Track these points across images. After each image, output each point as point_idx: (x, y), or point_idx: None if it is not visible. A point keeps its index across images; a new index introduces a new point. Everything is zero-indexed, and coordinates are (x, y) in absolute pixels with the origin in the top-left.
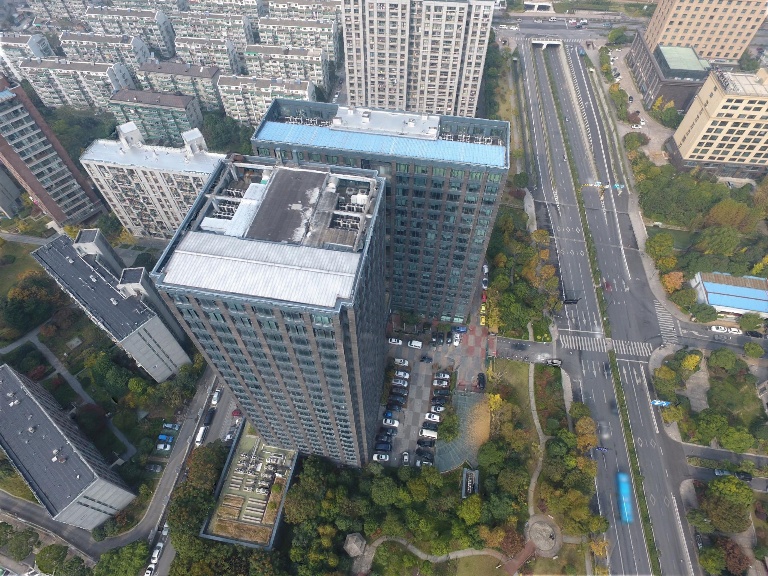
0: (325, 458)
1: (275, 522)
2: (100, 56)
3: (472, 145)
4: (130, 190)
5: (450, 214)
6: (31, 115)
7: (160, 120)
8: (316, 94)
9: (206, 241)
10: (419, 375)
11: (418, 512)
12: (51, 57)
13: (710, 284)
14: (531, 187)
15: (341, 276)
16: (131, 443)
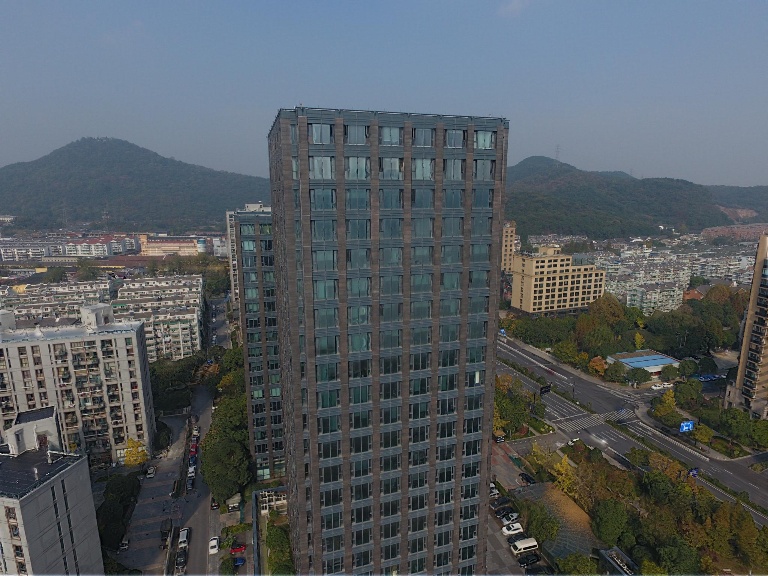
0: None
1: None
2: None
3: None
4: None
5: None
6: None
7: None
8: None
9: None
10: None
11: None
12: None
13: (622, 360)
14: None
15: None
16: None
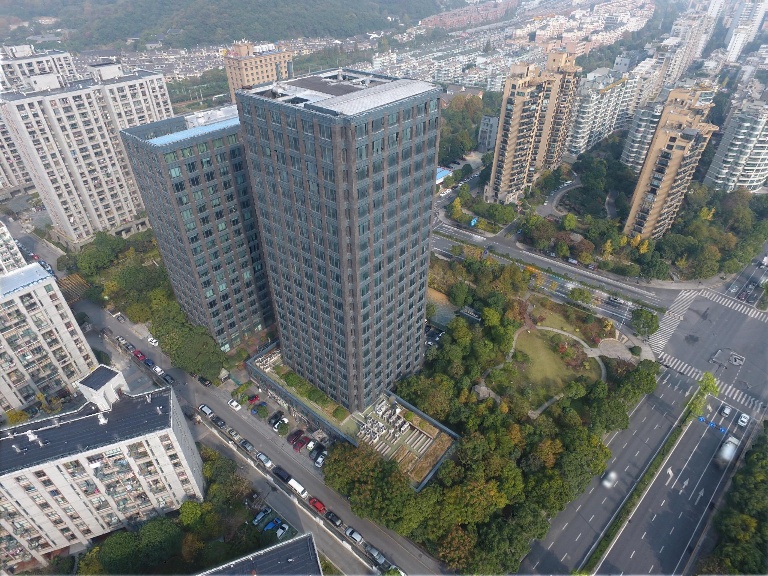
0: None
1: (438, 428)
2: None
3: None
4: None
5: None
6: None
7: None
8: None
9: None
10: None
11: None
12: None
13: None
14: None
15: (416, 82)
16: None
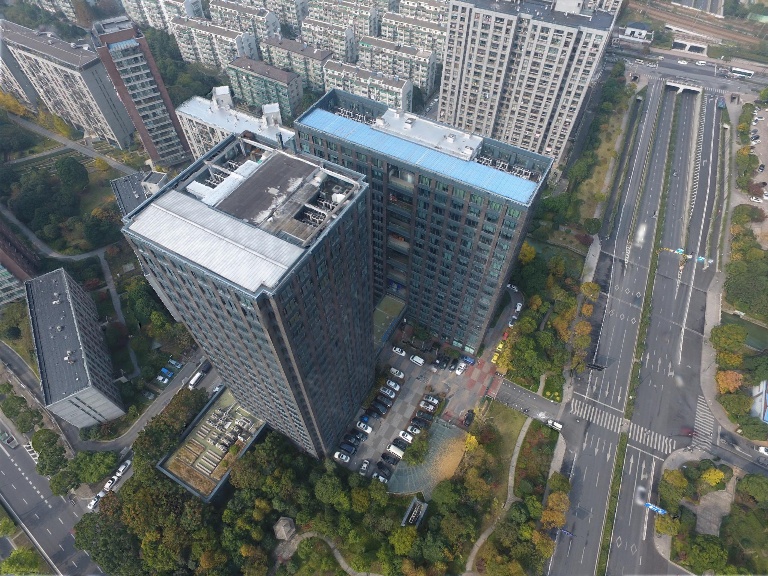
0: (288, 438)
1: (221, 479)
2: (238, 24)
3: (503, 174)
4: (210, 147)
5: (467, 239)
6: (148, 64)
7: (265, 90)
8: (413, 94)
9: (181, 202)
10: (410, 391)
11: (356, 522)
12: (197, 18)
13: None
14: (603, 236)
15: (275, 265)
16: (139, 367)
